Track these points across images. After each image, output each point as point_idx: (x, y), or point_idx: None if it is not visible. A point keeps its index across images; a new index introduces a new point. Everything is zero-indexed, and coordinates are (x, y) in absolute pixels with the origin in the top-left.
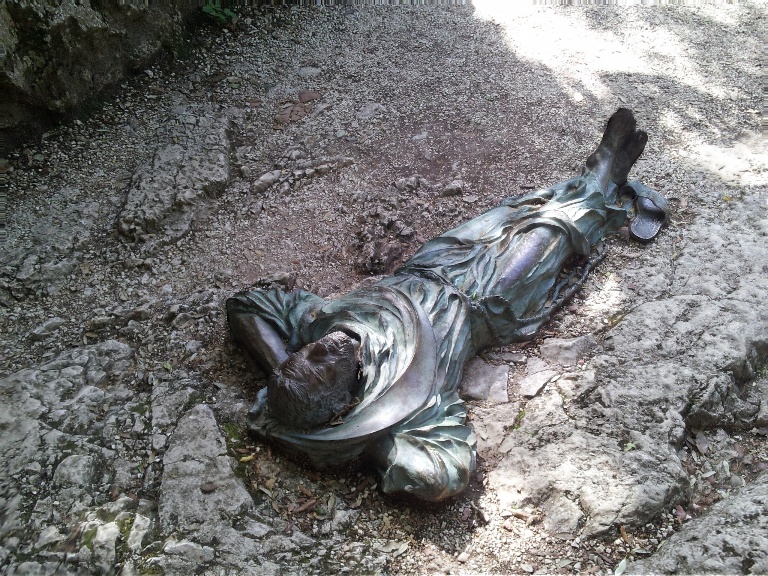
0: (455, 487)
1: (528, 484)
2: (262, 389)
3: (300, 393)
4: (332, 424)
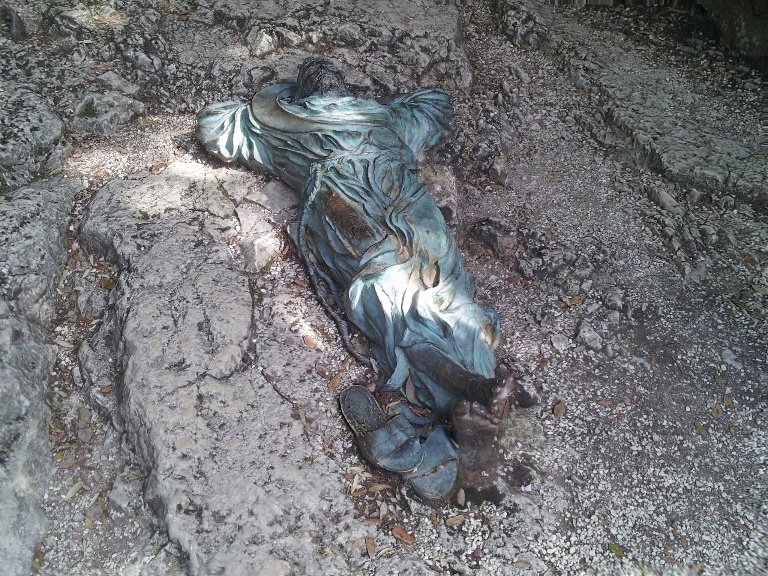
0: None
1: None
2: (352, 93)
3: None
4: (289, 98)
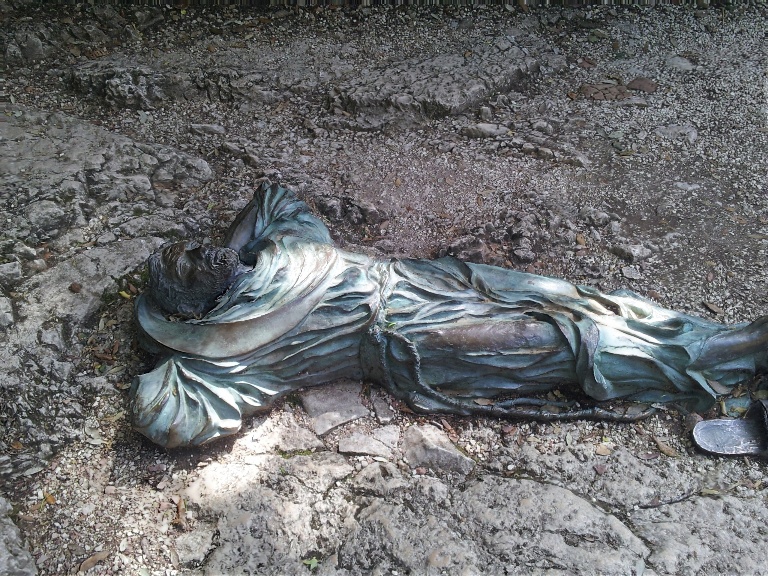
0: (154, 435)
1: (211, 496)
2: None
3: (154, 270)
4: (170, 317)
